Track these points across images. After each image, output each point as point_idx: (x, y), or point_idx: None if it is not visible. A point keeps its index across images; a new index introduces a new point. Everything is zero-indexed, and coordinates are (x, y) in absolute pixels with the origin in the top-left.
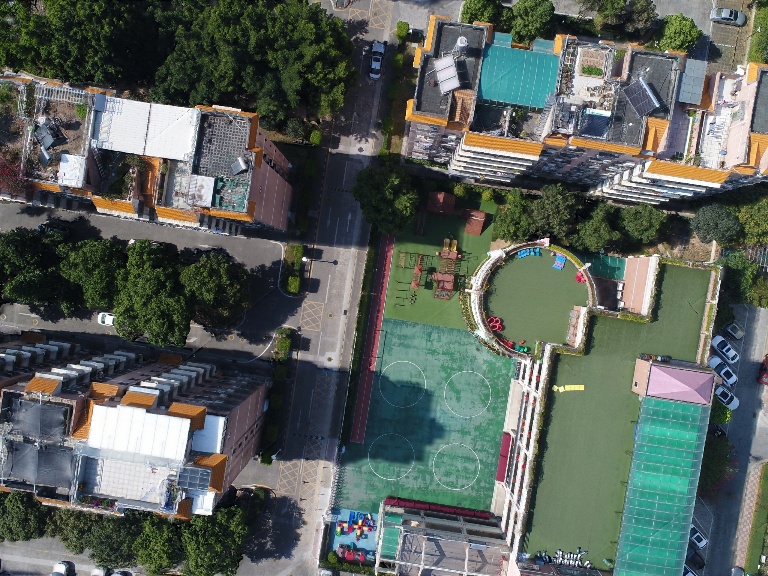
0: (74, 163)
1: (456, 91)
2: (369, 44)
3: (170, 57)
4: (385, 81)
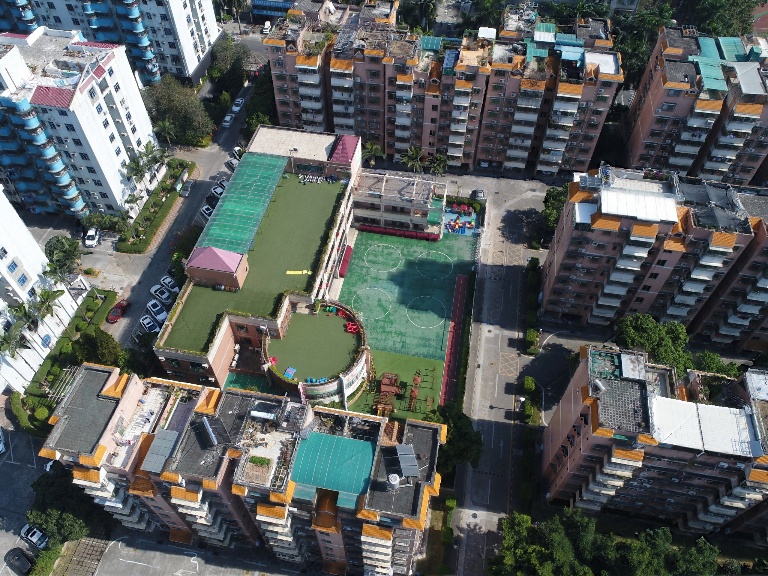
0: (761, 393)
1: None
2: None
3: (705, 574)
4: None
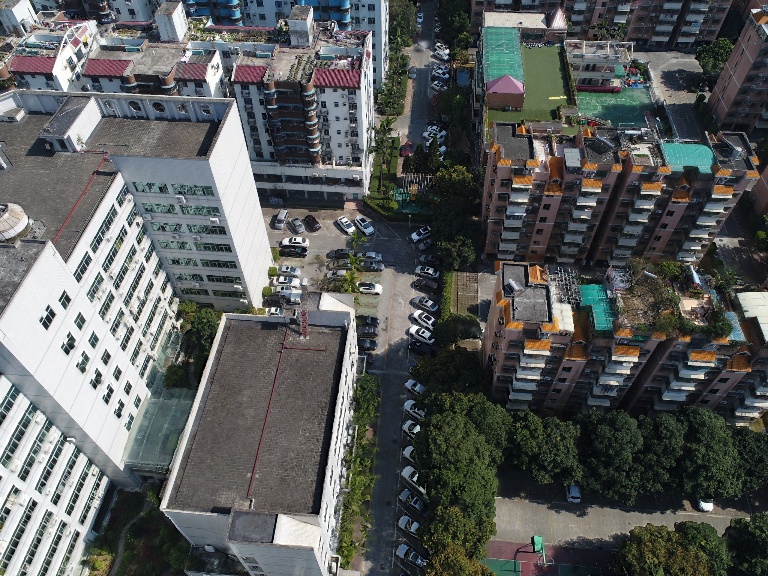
0: None
1: None
2: None
3: None
4: None
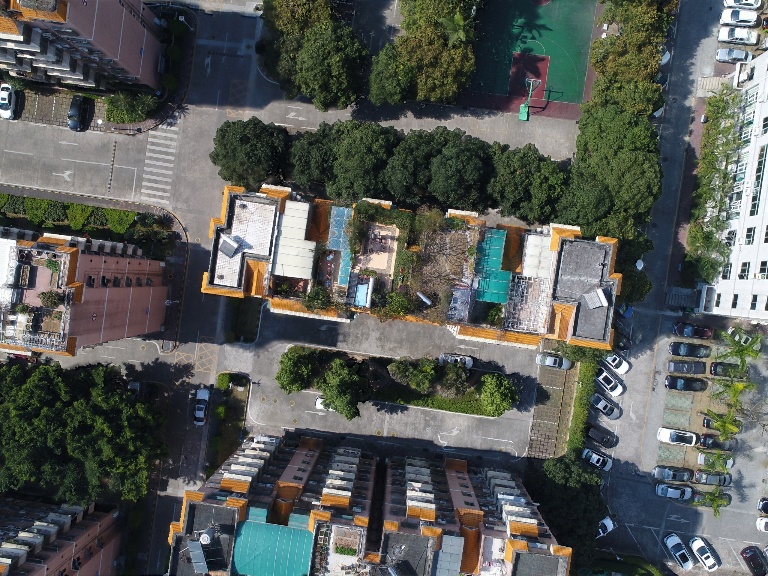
0: None
1: (209, 571)
2: (195, 387)
3: None
4: (212, 424)
